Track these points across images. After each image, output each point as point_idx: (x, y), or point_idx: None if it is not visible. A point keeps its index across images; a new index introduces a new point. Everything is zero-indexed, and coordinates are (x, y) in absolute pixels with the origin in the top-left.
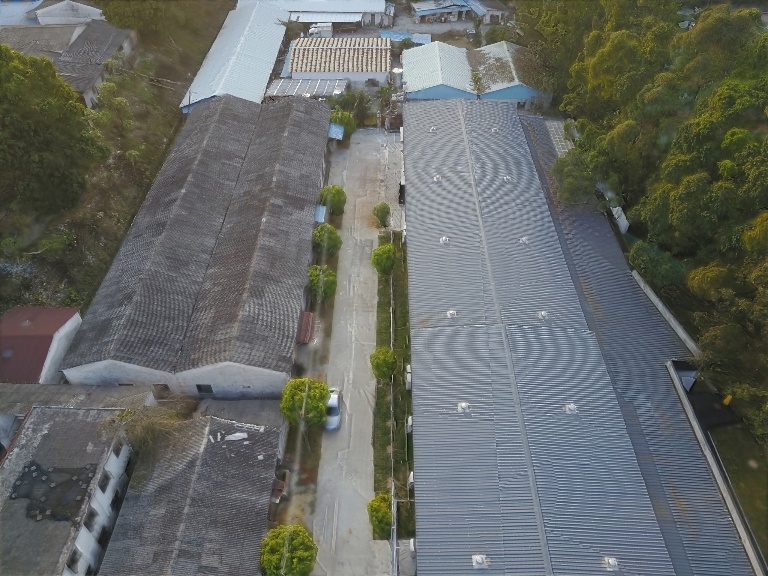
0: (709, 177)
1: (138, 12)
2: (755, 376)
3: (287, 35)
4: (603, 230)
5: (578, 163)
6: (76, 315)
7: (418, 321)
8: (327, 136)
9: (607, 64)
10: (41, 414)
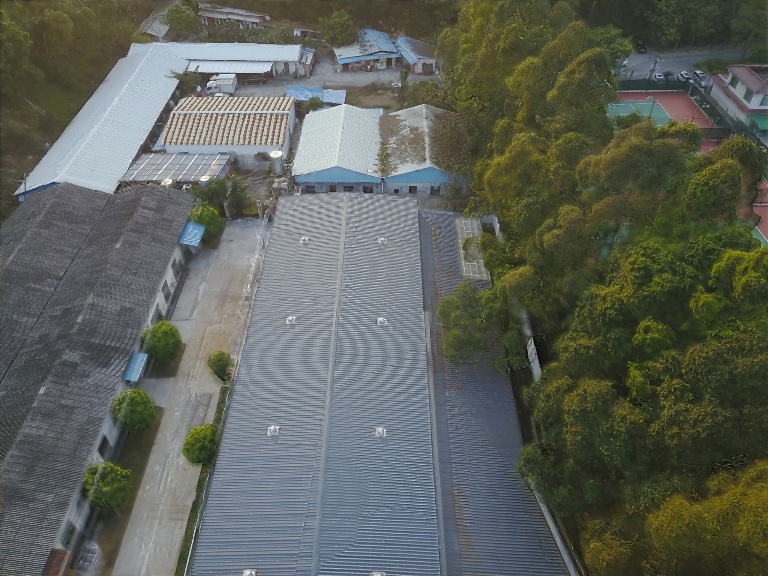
0: (613, 391)
1: None
2: None
3: (181, 89)
4: (501, 397)
5: (472, 303)
6: None
7: None
8: (178, 242)
9: (503, 181)
10: None
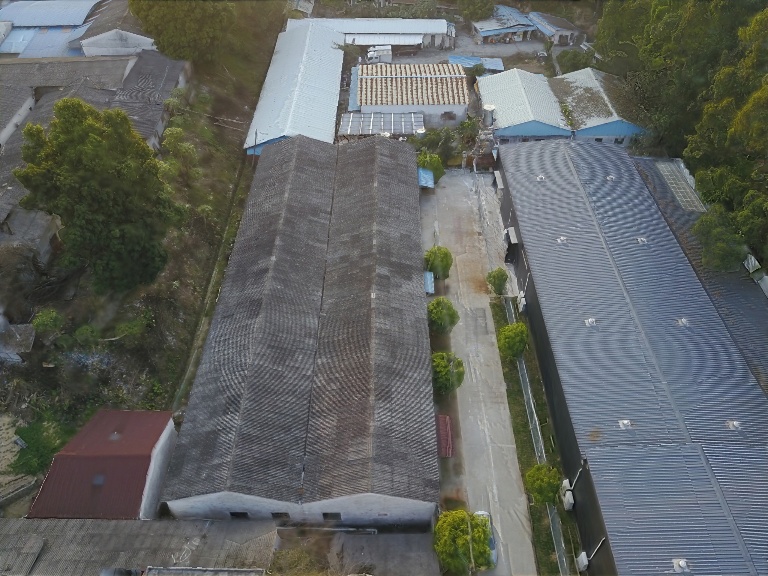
0: None
1: (194, 41)
2: None
3: (344, 60)
4: (759, 302)
5: (725, 223)
6: (170, 421)
7: (586, 433)
8: (418, 184)
9: (766, 112)
10: None
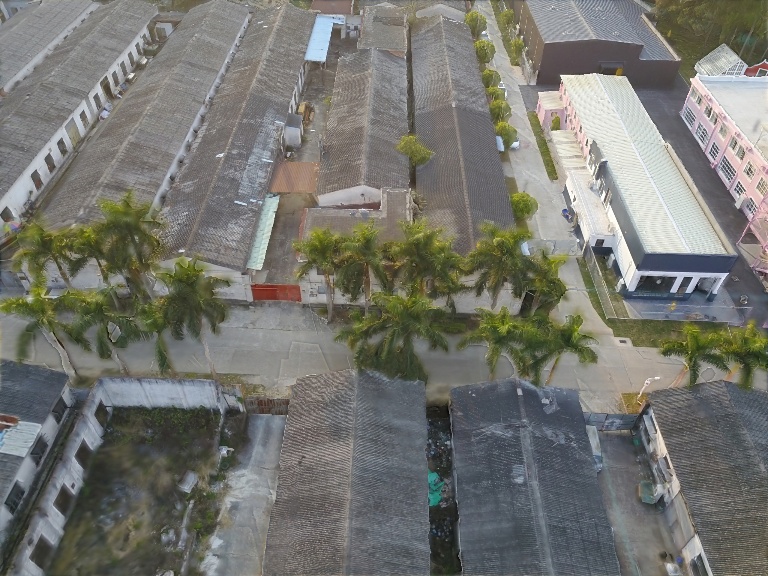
0: None
1: None
2: (685, 38)
3: None
4: None
5: None
6: None
7: None
8: None
9: None
10: (370, 7)
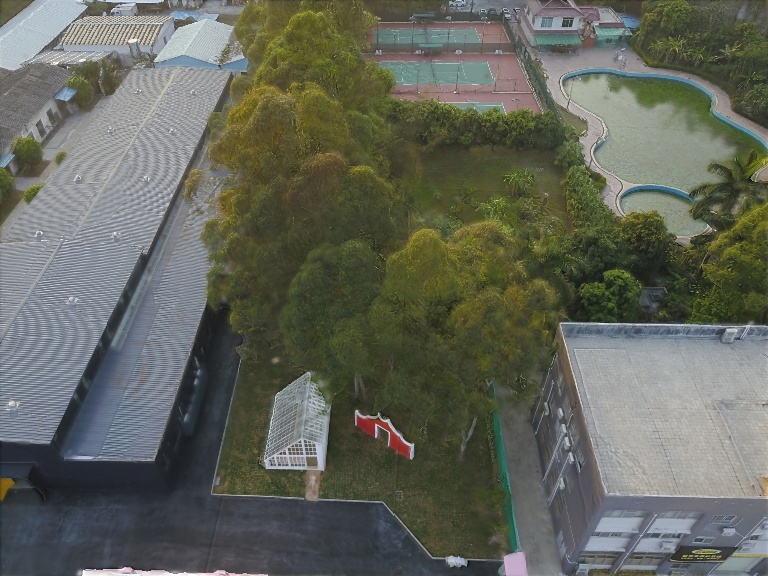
0: None
1: None
2: None
3: (90, 14)
4: None
5: None
6: None
7: (8, 239)
8: (53, 97)
9: (241, 28)
10: None
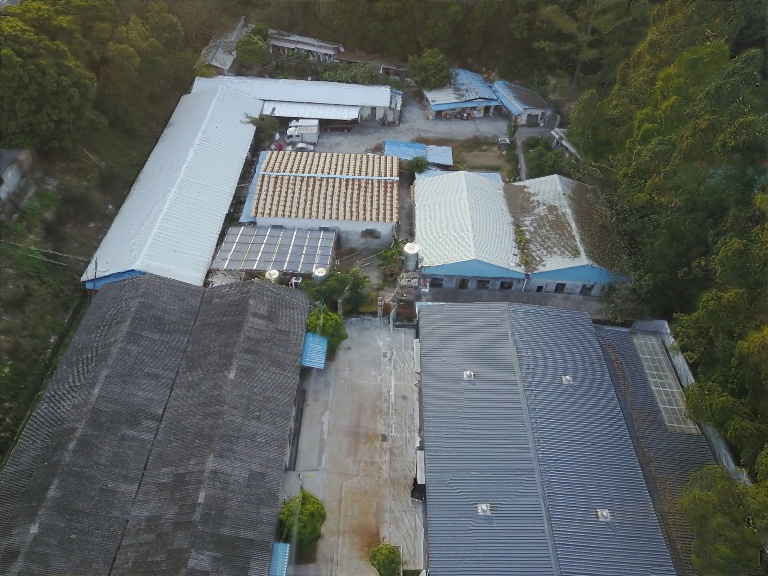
0: None
1: (30, 126)
2: None
3: (257, 137)
4: None
5: (728, 498)
6: None
7: None
8: (300, 365)
9: None
10: None
